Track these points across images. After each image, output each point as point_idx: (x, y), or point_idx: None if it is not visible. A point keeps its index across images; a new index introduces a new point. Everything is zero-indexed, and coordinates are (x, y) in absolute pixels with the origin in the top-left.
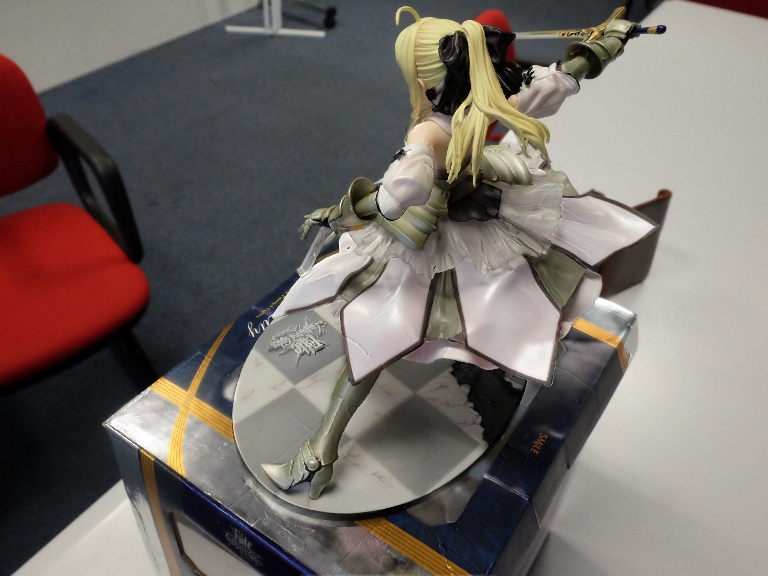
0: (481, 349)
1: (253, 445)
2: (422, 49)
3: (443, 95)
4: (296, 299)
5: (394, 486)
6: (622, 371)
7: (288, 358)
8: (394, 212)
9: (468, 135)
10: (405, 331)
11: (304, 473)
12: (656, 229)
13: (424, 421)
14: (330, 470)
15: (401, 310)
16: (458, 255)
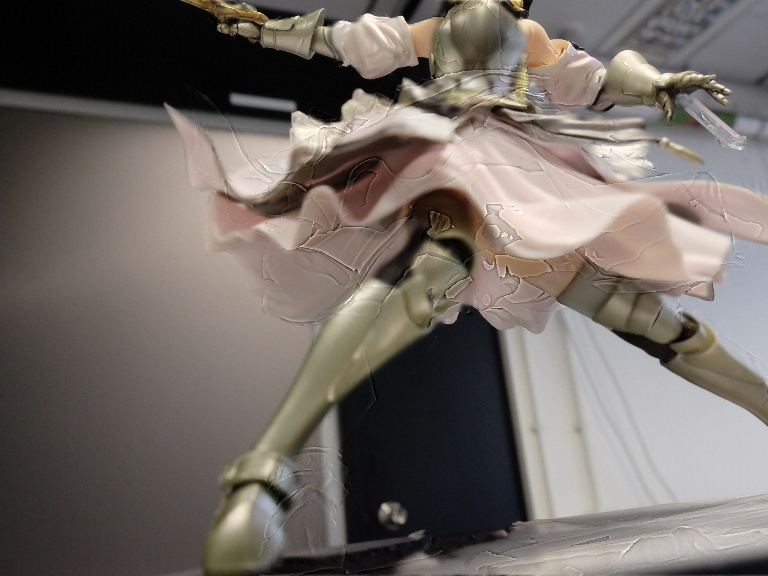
0: None
1: None
2: None
3: None
4: None
5: None
6: None
7: None
8: None
9: None
10: None
11: None
12: None
13: None
14: None
15: None
16: None
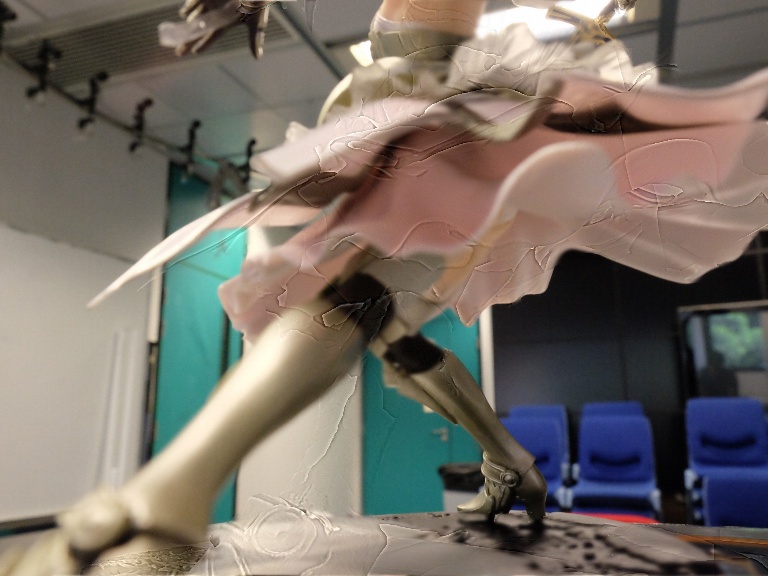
0: None
1: None
2: None
3: None
4: (199, 240)
5: None
6: None
7: None
8: None
9: None
10: None
11: None
12: None
13: None
14: None
15: None
16: None
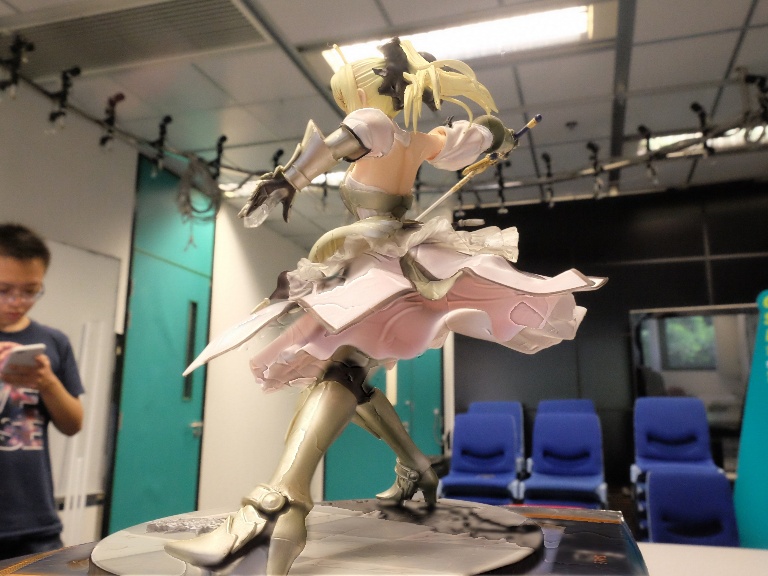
0: (493, 279)
1: (138, 567)
2: (359, 64)
3: (388, 74)
4: (221, 344)
5: (416, 572)
6: (643, 561)
7: (181, 534)
8: (363, 130)
9: (422, 79)
10: (391, 281)
11: (257, 522)
12: (606, 280)
13: (423, 547)
14: (302, 523)
15: (379, 272)
16: (430, 227)
